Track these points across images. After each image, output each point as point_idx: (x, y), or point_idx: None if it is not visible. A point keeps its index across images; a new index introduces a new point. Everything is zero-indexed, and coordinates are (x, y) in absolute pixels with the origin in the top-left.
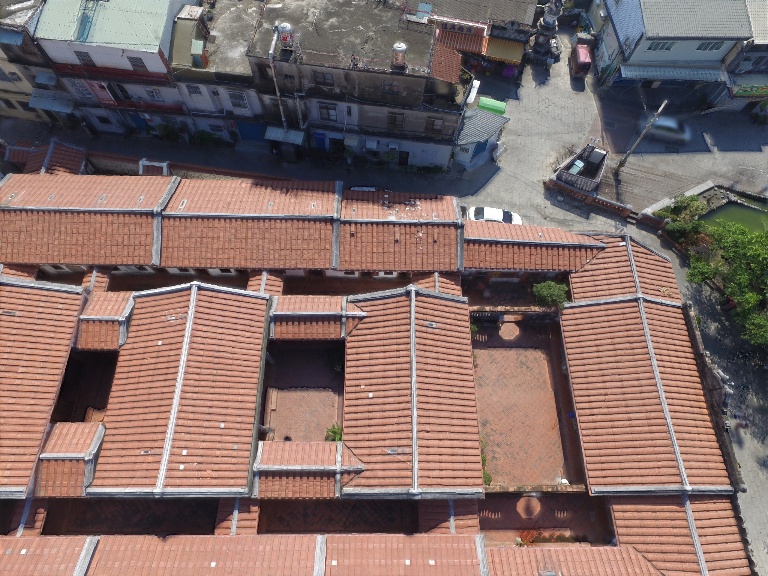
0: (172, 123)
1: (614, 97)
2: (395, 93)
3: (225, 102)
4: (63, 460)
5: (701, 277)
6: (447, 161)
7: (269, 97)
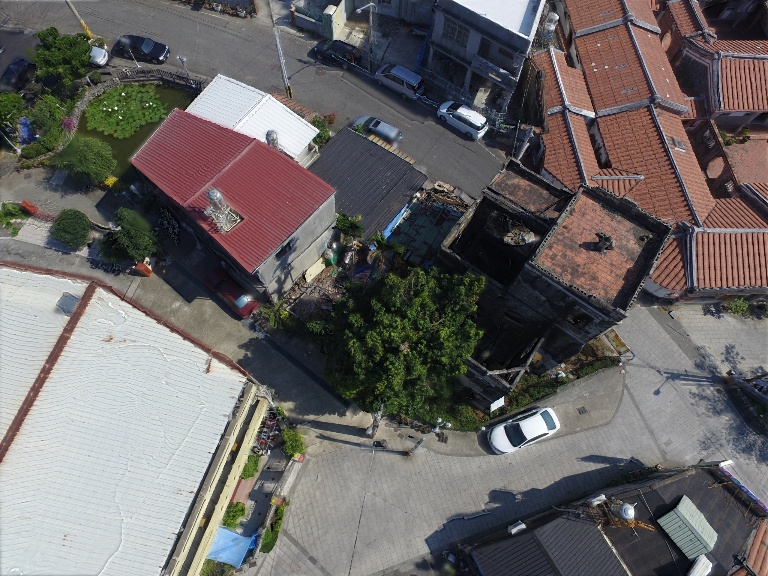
0: None
1: None
2: None
3: None
4: None
5: None
6: None
7: None
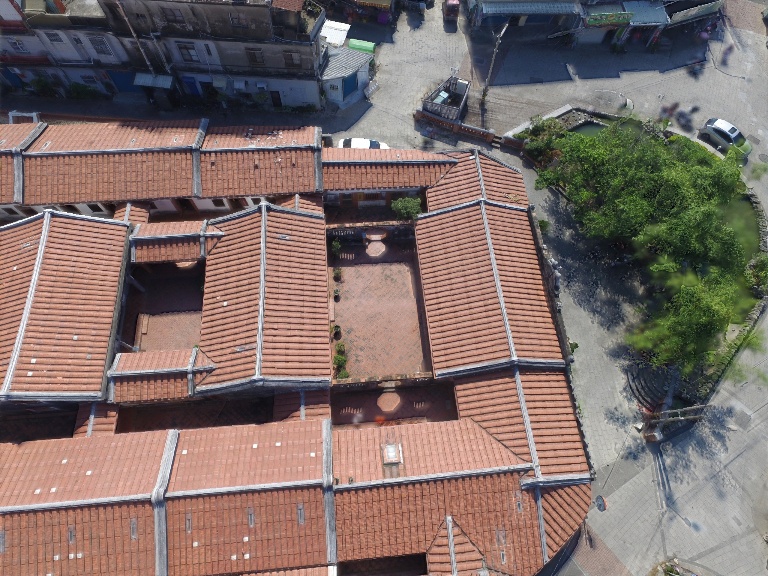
0: (44, 77)
1: (484, 36)
2: (245, 26)
3: (90, 50)
4: None
5: (545, 183)
6: (318, 99)
7: (129, 40)
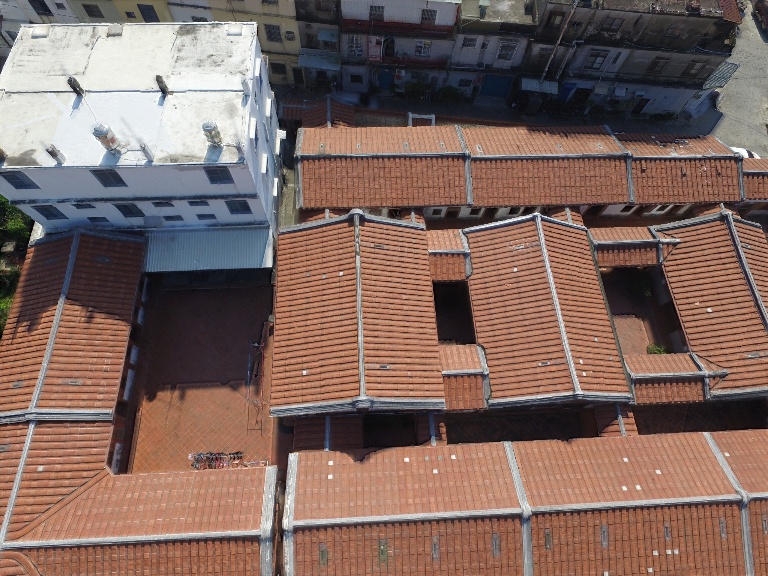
0: (422, 80)
1: None
2: (675, 37)
3: (488, 55)
4: (462, 376)
5: None
6: (682, 107)
7: (541, 47)
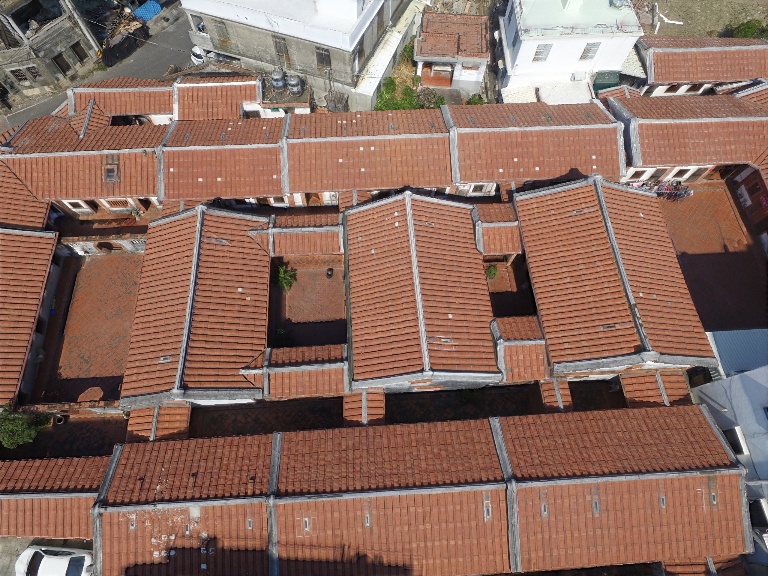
0: None
1: None
2: None
3: None
4: None
5: None
6: None
7: None
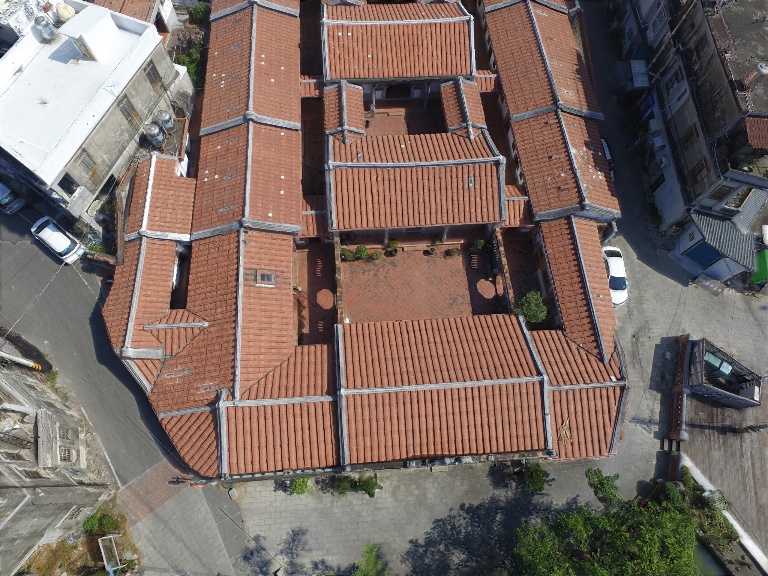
0: (623, 7)
1: None
2: (715, 109)
3: None
4: None
5: (596, 481)
6: (670, 222)
7: None
